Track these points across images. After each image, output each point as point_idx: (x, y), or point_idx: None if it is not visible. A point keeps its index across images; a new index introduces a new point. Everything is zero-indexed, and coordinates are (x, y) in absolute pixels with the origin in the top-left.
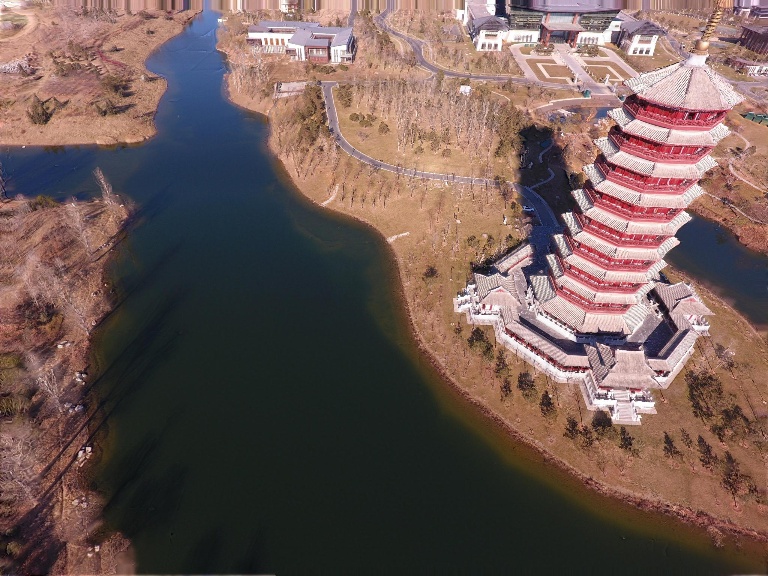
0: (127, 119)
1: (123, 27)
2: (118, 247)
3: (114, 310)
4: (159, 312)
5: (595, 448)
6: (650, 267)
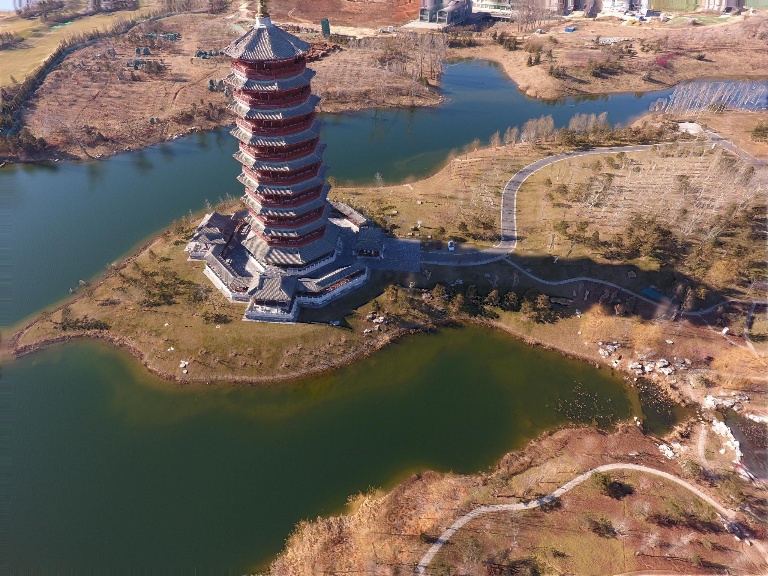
0: (555, 83)
1: (764, 50)
2: (394, 108)
3: (338, 114)
4: (335, 123)
5: (175, 221)
6: (248, 193)
